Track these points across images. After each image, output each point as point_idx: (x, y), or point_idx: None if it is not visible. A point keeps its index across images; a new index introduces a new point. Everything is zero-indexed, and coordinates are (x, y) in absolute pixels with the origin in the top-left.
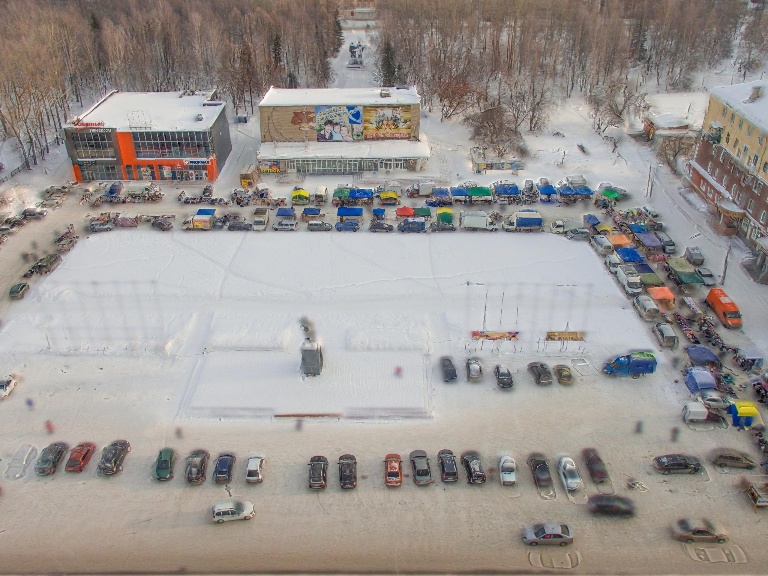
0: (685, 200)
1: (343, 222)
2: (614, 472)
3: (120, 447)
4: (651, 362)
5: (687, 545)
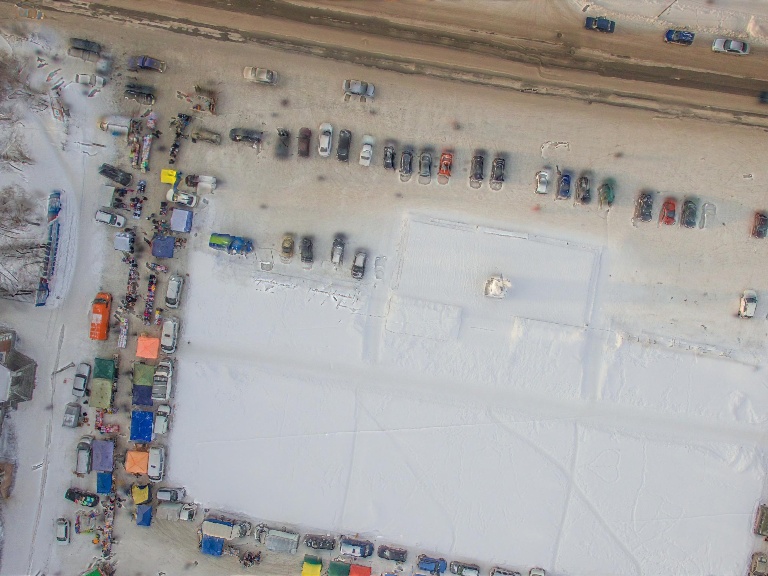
0: (3, 554)
1: (438, 568)
2: (292, 148)
3: None
4: (216, 237)
5: (276, 82)
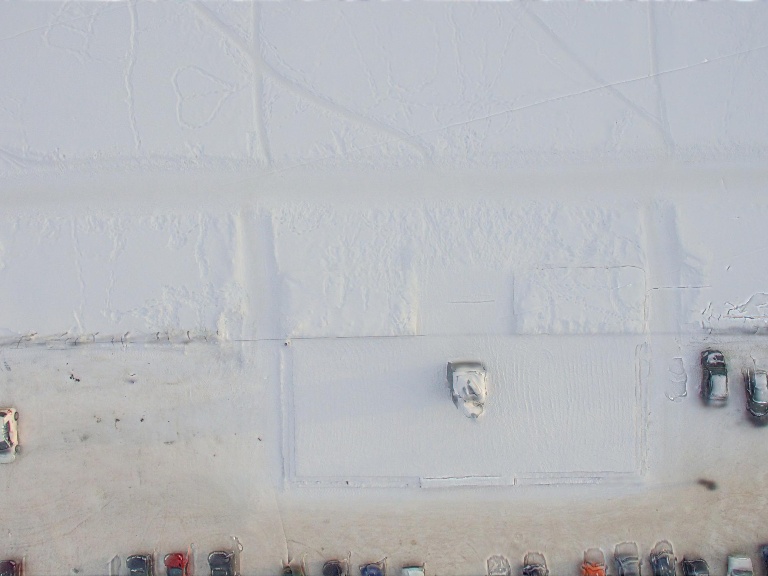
0: None
1: None
2: None
3: (229, 554)
4: None
5: None
